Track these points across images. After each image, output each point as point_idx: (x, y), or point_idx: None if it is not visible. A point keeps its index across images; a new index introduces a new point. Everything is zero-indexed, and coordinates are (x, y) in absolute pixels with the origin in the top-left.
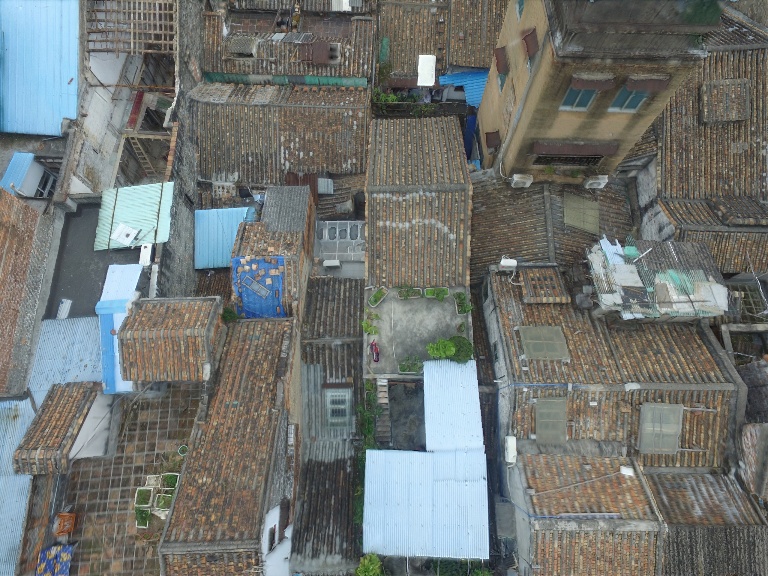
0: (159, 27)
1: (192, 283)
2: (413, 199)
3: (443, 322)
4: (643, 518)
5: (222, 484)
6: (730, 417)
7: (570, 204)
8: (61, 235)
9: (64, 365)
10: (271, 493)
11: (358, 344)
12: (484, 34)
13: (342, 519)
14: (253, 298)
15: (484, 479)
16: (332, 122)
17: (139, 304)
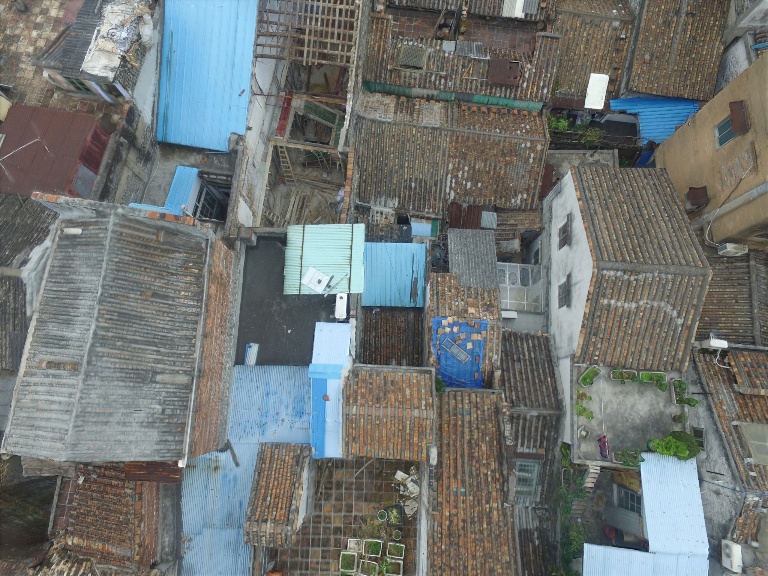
0: (337, 36)
1: (360, 322)
2: (646, 279)
3: (656, 409)
4: None
5: None
6: None
7: None
8: (243, 271)
9: (261, 417)
10: None
11: (555, 417)
12: (673, 58)
13: None
14: (451, 361)
15: None
16: (507, 152)
17: (354, 371)
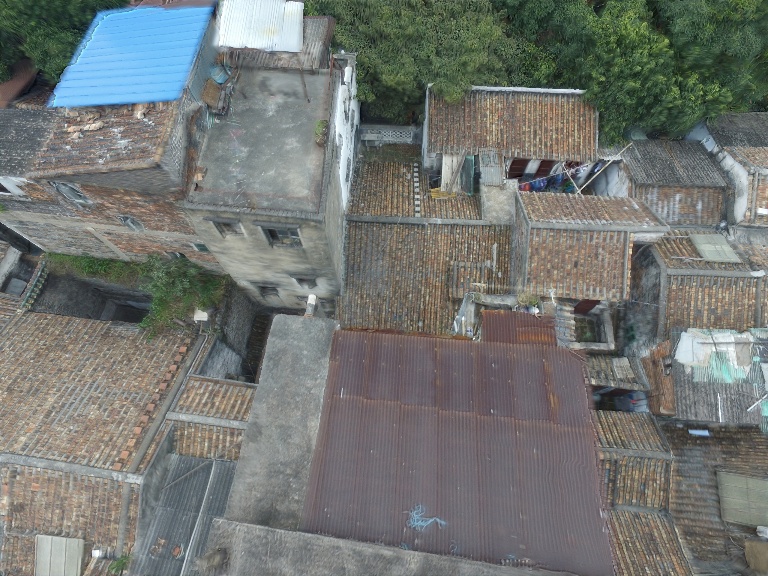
0: None
1: None
2: None
3: None
4: (767, 176)
5: None
6: None
7: None
8: None
9: None
10: None
11: None
12: None
13: None
14: None
15: None
16: None
17: None
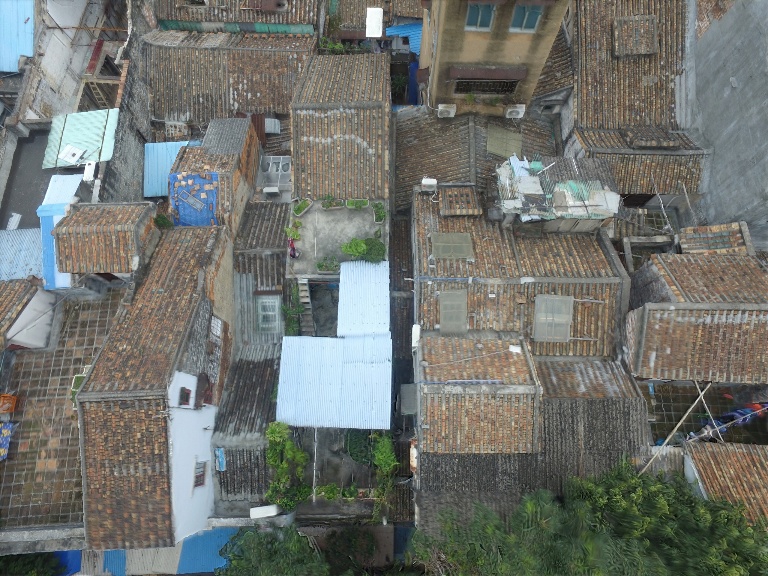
0: None
1: None
2: (334, 115)
3: (362, 230)
4: (522, 383)
5: (140, 350)
6: (617, 308)
7: (493, 134)
8: (13, 157)
9: (11, 269)
10: (184, 358)
11: None
12: None
13: (265, 406)
14: (189, 211)
15: (389, 361)
16: (278, 64)
17: (77, 207)
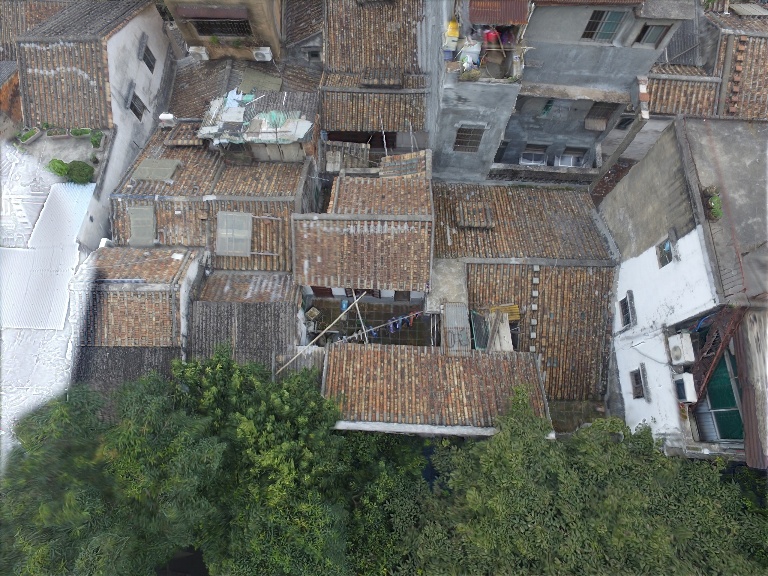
0: None
1: None
2: (55, 48)
3: (84, 157)
4: (162, 282)
5: None
6: None
7: (249, 77)
8: None
9: None
10: None
11: None
12: None
13: None
14: None
15: (72, 270)
16: None
17: None
